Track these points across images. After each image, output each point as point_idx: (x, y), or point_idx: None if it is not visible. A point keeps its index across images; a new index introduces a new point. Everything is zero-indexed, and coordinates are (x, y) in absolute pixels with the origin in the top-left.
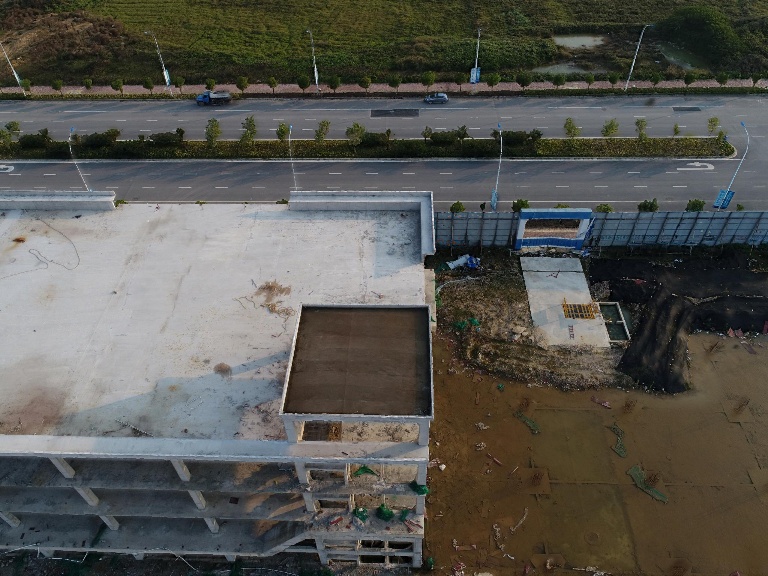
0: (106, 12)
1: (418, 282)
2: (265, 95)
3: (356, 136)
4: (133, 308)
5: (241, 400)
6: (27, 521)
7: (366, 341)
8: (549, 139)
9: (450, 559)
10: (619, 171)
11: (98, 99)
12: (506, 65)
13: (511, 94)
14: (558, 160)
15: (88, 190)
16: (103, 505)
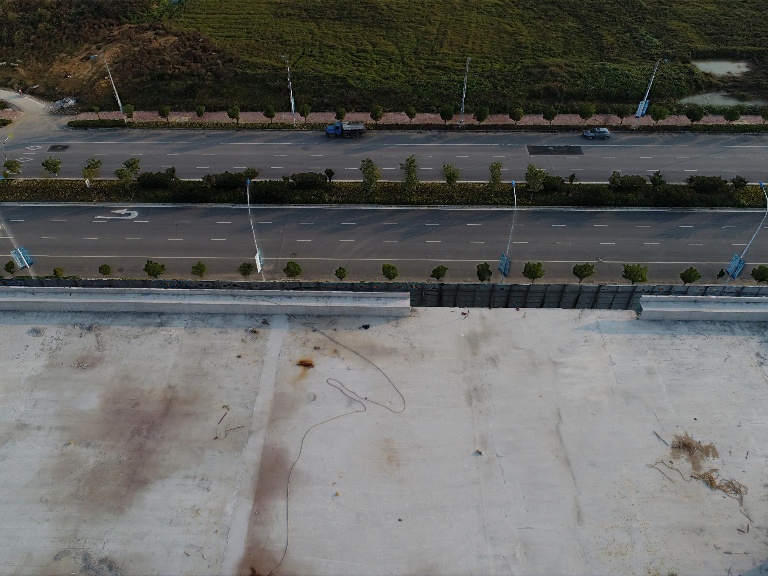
0: (186, 24)
1: None
2: (401, 126)
3: (537, 182)
4: (518, 480)
5: None
6: None
7: None
8: None
9: None
10: None
11: (210, 128)
12: (655, 94)
13: (678, 129)
14: (765, 211)
15: (257, 251)
16: None
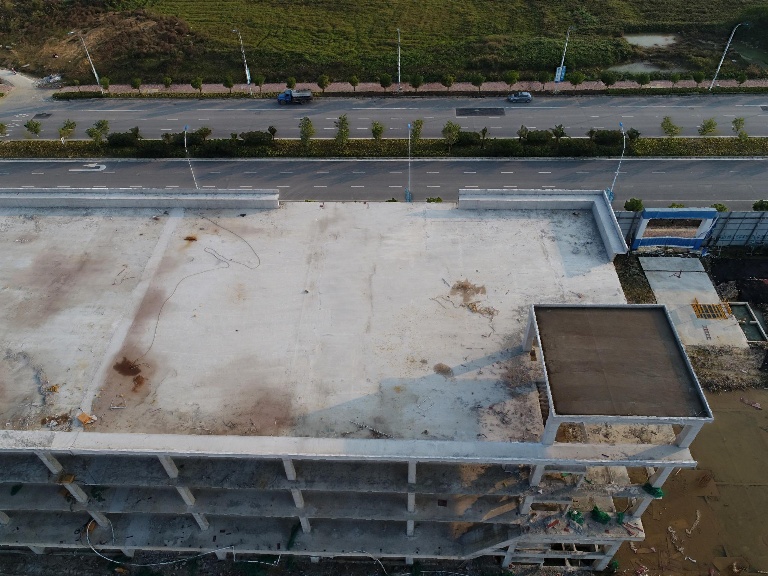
0: (166, 10)
1: (614, 281)
2: (345, 94)
3: (452, 135)
4: (330, 307)
5: (472, 401)
6: (216, 523)
7: (612, 341)
8: (643, 138)
9: (631, 562)
10: (720, 170)
11: (177, 98)
12: (582, 64)
13: (594, 93)
14: (656, 159)
15: None
16: (309, 507)
